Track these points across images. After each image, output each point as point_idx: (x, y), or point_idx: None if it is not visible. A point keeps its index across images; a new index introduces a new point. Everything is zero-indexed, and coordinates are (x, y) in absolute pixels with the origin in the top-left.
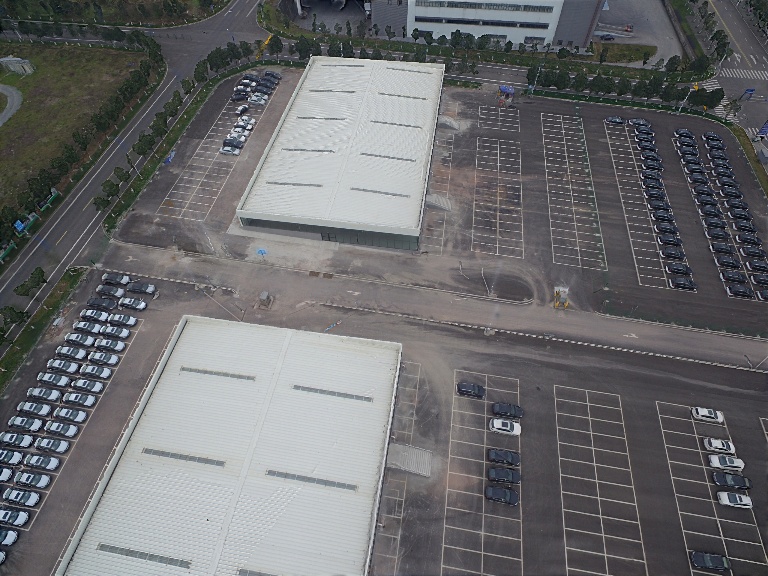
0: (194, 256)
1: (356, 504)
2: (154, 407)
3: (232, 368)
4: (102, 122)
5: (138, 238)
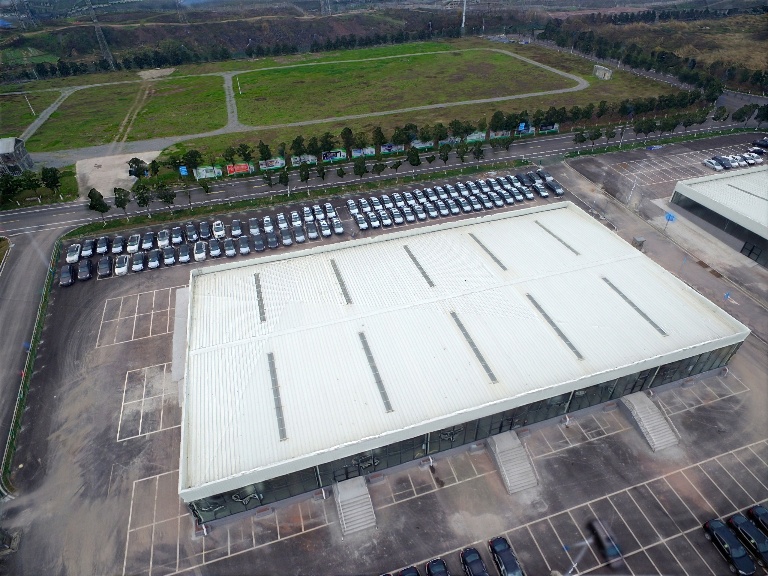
0: (609, 197)
1: (570, 364)
2: (498, 224)
3: (569, 241)
4: (627, 107)
5: (581, 169)
